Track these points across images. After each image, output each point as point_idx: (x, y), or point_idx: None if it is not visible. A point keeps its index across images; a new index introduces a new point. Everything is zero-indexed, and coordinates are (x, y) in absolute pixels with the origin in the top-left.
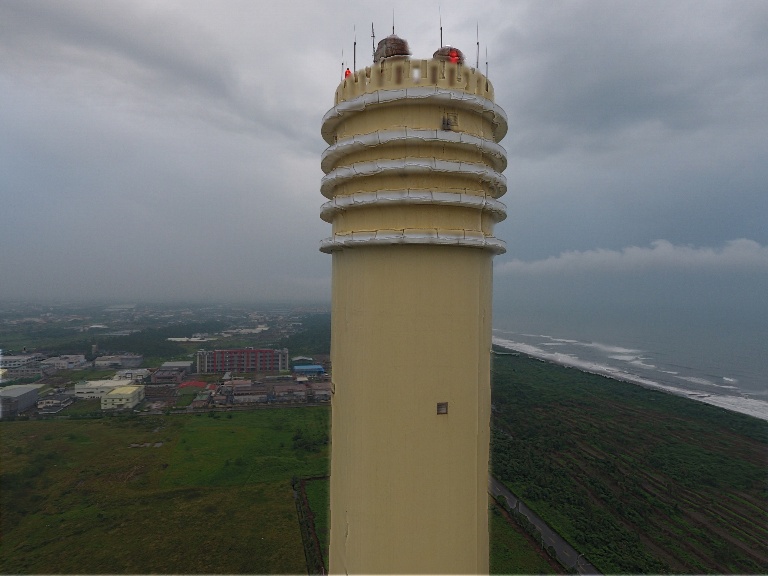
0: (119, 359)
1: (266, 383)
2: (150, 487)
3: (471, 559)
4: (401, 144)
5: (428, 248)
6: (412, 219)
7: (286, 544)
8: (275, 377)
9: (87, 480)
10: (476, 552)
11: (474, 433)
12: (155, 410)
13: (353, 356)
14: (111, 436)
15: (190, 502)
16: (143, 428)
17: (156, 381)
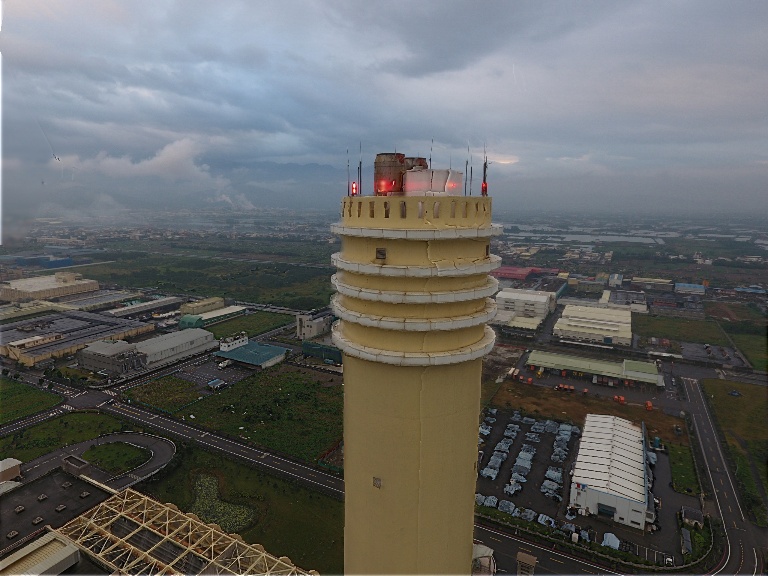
0: None
1: None
2: None
3: None
4: None
5: None
6: None
7: None
8: None
9: None
10: None
11: None
12: None
13: None
14: None
15: None
16: None
17: None
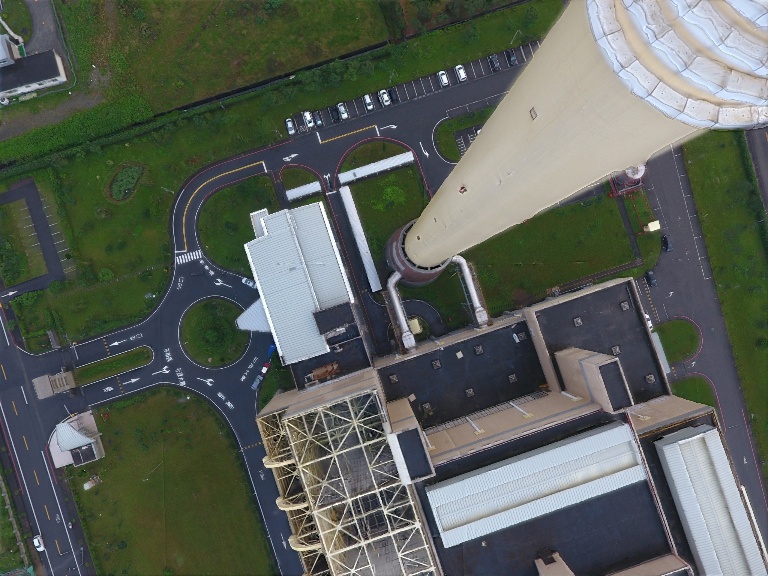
0: None
1: None
2: None
3: None
4: None
5: None
6: None
7: None
8: None
9: None
10: None
11: None
12: None
13: (573, 133)
14: None
15: None
16: None
17: None
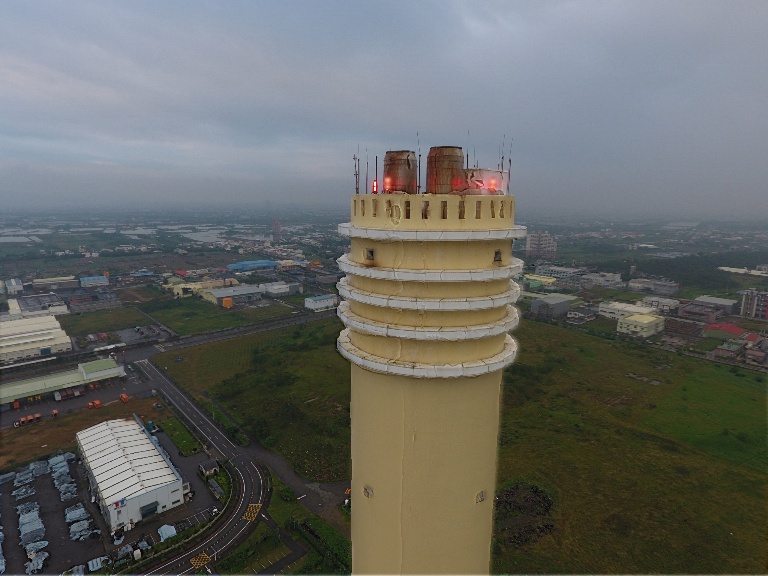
0: (652, 284)
1: None
2: (629, 420)
3: None
4: None
5: None
6: None
7: (762, 558)
8: None
9: (579, 391)
10: None
11: (398, 528)
12: (669, 346)
13: None
14: (614, 359)
15: (663, 453)
16: (647, 361)
17: (683, 315)
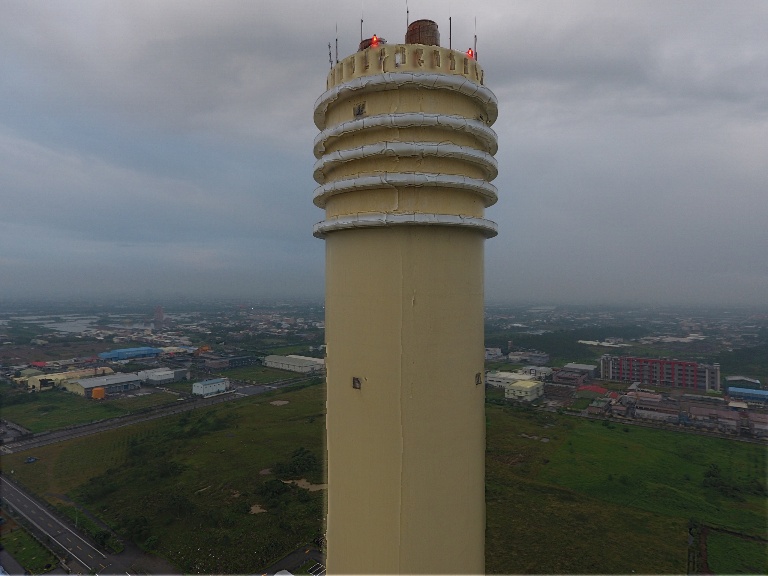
0: (528, 356)
1: (683, 402)
2: (529, 476)
3: (394, 544)
4: (328, 145)
5: (341, 234)
6: (336, 209)
7: None
8: (697, 397)
9: None
10: (400, 540)
11: (398, 417)
12: (550, 407)
13: None
14: (507, 422)
15: (563, 503)
16: (535, 421)
17: (557, 380)
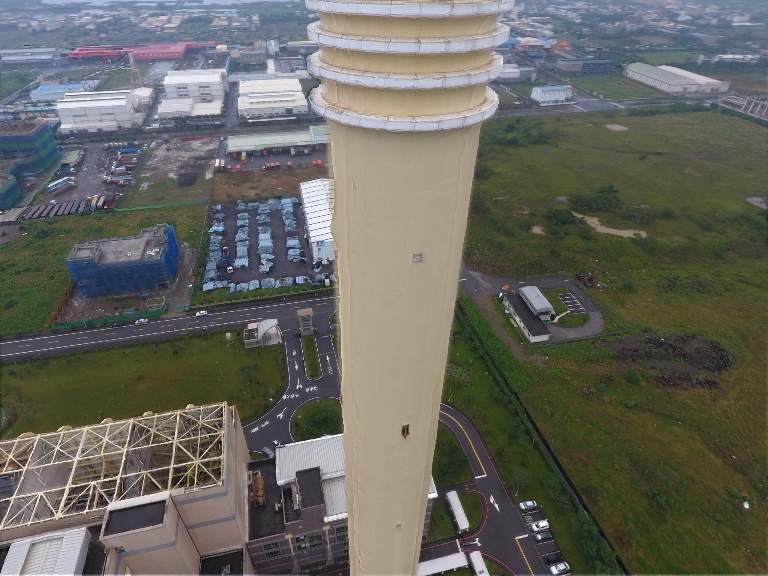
0: None
1: None
2: None
3: None
4: None
5: None
6: None
7: None
8: None
9: None
10: (350, 333)
11: None
12: None
13: None
14: None
15: None
16: None
17: None
